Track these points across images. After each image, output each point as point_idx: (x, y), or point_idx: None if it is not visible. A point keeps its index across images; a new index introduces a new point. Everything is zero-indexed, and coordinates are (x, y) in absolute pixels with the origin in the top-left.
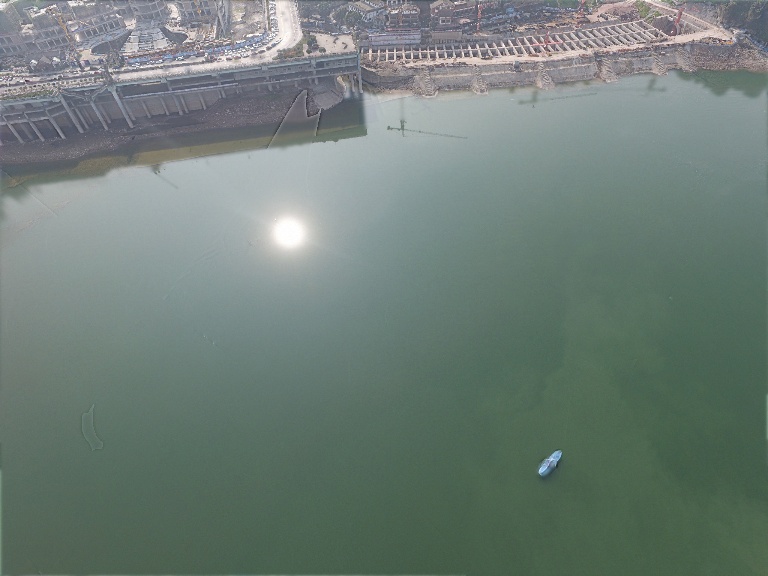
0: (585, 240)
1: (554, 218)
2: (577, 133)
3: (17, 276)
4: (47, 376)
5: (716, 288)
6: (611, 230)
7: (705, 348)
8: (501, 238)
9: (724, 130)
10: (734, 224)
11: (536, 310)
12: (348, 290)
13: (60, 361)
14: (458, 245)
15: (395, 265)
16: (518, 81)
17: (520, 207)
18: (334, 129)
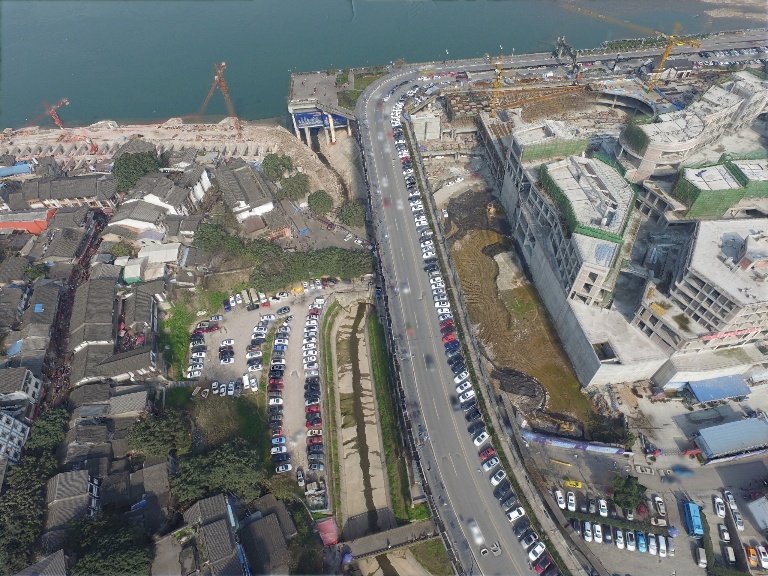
0: (208, 27)
1: (214, 36)
2: (138, 78)
3: (529, 18)
4: (483, 9)
5: (169, 15)
6: (190, 30)
7: (199, 3)
8: (252, 26)
9: (30, 77)
10: (125, 27)
11: None
12: (342, 19)
13: (481, 11)
14: None
15: None
16: None
17: (228, 40)
18: None
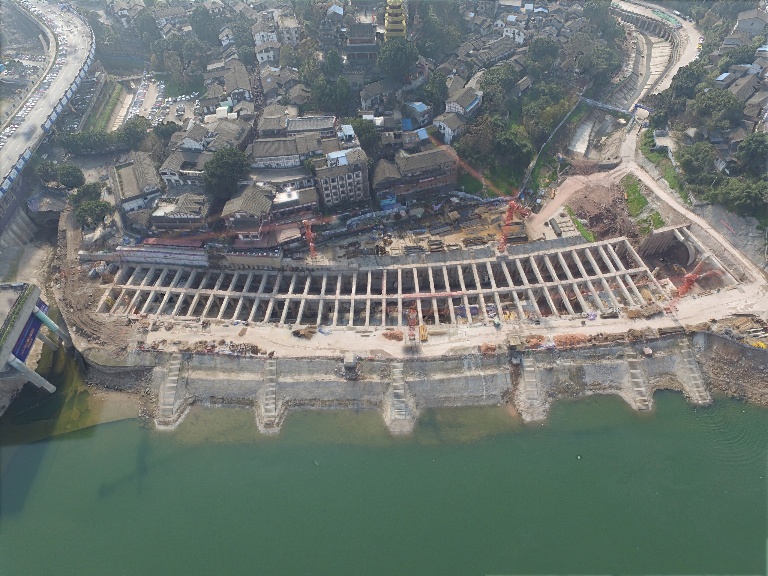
0: None
1: None
2: None
3: None
4: None
5: None
6: None
7: None
8: None
9: None
10: None
11: None
12: None
13: None
14: None
15: None
16: (348, 399)
17: None
18: None
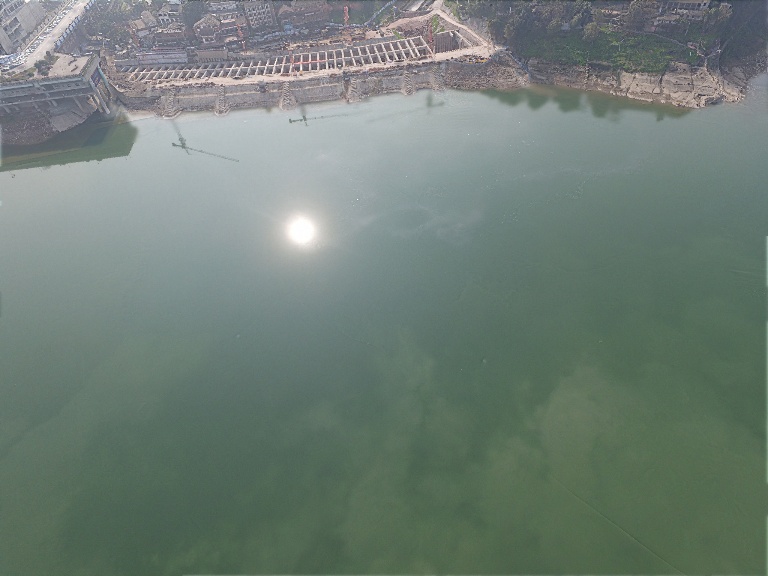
0: (199, 273)
1: (189, 249)
2: (278, 157)
3: None
4: None
5: (287, 326)
6: (231, 262)
7: (229, 391)
8: (118, 270)
9: (422, 155)
10: (348, 258)
11: (94, 348)
12: None
13: None
14: (67, 278)
15: (8, 297)
16: (262, 101)
17: (165, 237)
18: (53, 152)
